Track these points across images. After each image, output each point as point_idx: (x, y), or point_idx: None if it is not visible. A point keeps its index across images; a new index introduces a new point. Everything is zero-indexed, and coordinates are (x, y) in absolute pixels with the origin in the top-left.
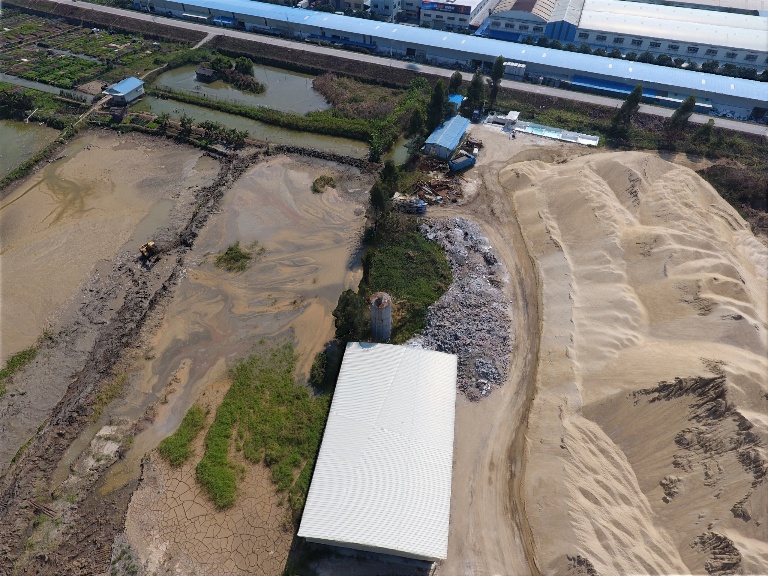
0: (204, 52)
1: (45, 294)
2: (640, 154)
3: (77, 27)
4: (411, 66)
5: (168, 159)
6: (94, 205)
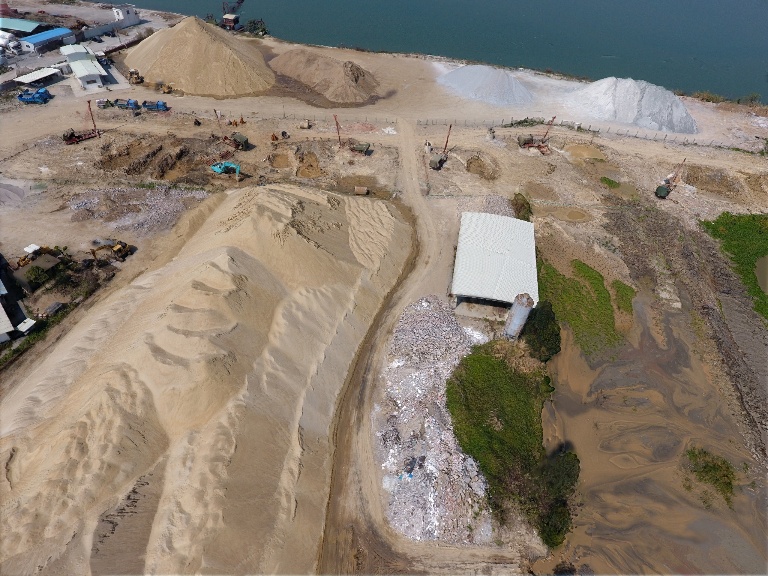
0: None
1: None
2: None
3: None
4: None
5: None
6: None
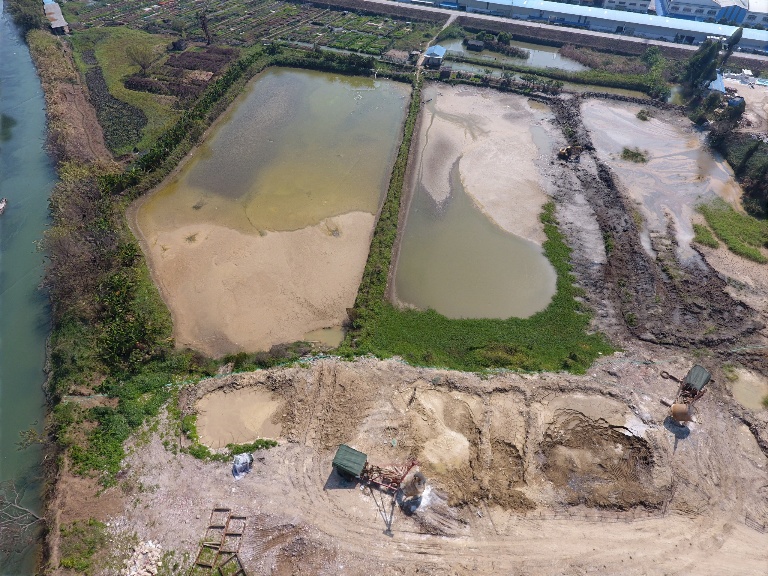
0: (458, 29)
1: (521, 176)
2: None
3: (327, 10)
4: (635, 39)
5: (507, 102)
6: (489, 129)
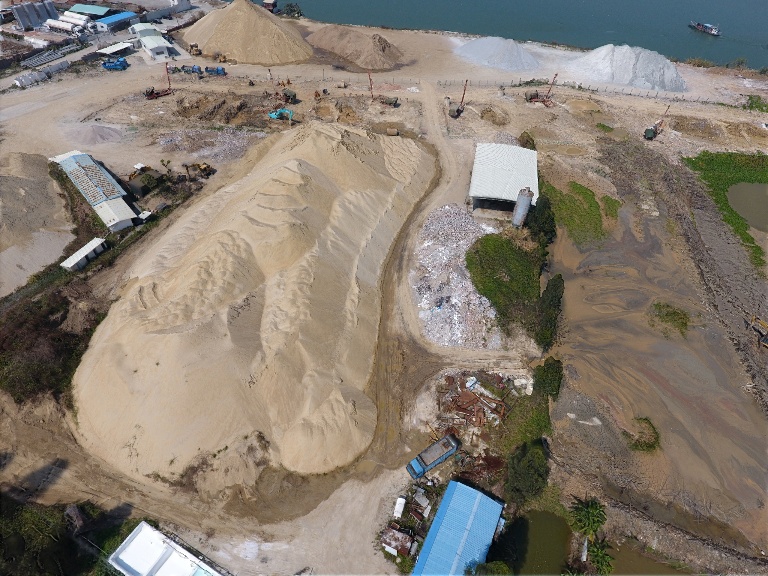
0: None
1: None
2: (192, 342)
3: None
4: None
5: None
6: None
